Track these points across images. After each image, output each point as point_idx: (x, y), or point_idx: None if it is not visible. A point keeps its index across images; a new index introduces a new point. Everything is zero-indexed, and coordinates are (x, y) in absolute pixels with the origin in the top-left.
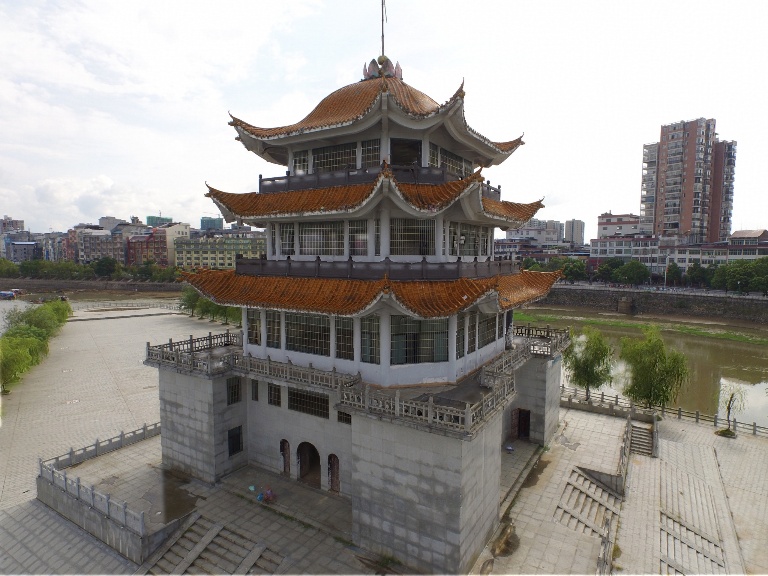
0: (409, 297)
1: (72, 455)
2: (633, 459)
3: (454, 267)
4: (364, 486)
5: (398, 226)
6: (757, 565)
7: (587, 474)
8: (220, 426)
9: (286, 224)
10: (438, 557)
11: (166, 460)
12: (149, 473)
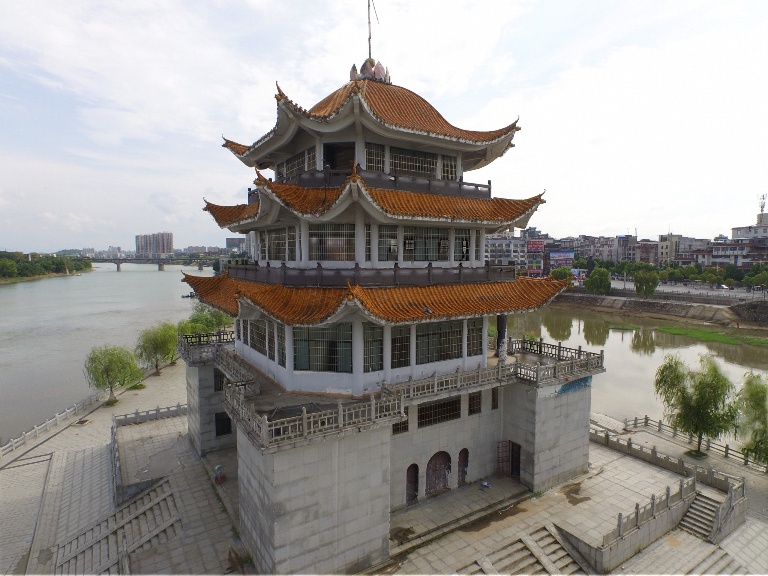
0: (296, 303)
1: (137, 415)
2: (671, 537)
3: (351, 273)
4: (241, 483)
5: (317, 231)
6: None
7: (563, 536)
8: (207, 408)
9: (262, 232)
10: (267, 569)
11: (189, 431)
12: (172, 439)
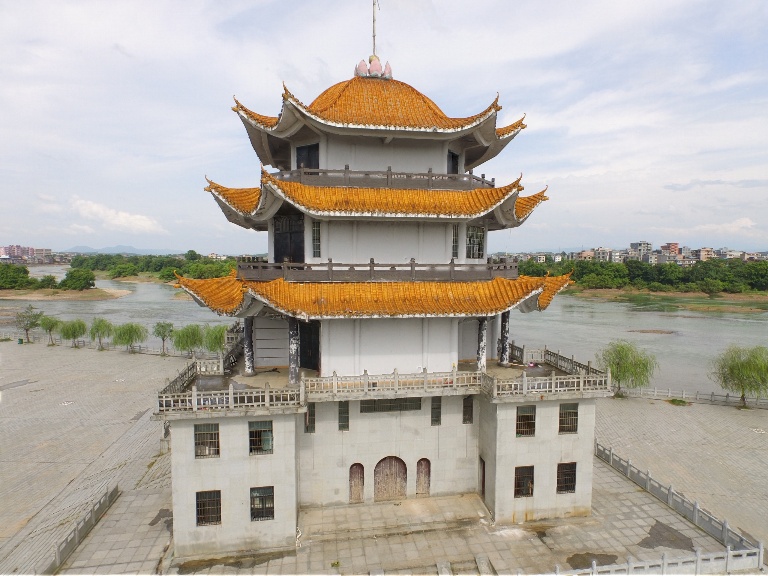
0: None
1: None
2: None
3: None
4: None
5: None
6: (4, 537)
7: None
8: None
9: None
10: None
11: None
12: None
